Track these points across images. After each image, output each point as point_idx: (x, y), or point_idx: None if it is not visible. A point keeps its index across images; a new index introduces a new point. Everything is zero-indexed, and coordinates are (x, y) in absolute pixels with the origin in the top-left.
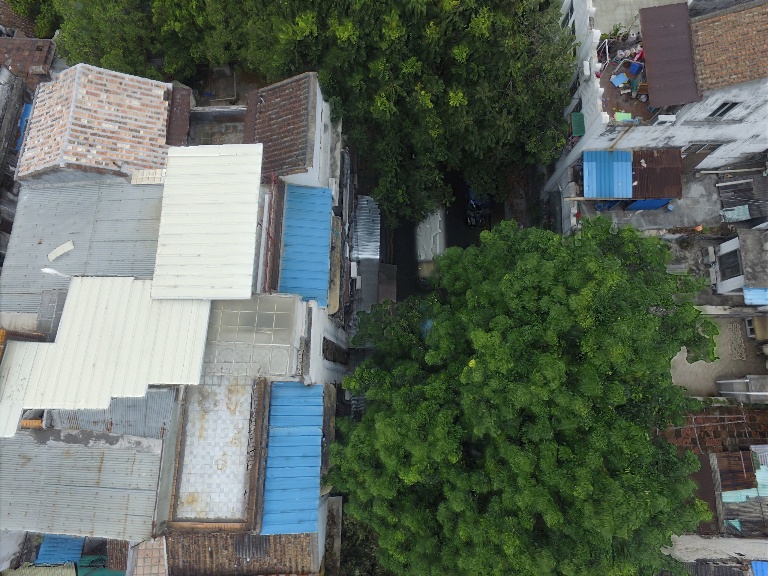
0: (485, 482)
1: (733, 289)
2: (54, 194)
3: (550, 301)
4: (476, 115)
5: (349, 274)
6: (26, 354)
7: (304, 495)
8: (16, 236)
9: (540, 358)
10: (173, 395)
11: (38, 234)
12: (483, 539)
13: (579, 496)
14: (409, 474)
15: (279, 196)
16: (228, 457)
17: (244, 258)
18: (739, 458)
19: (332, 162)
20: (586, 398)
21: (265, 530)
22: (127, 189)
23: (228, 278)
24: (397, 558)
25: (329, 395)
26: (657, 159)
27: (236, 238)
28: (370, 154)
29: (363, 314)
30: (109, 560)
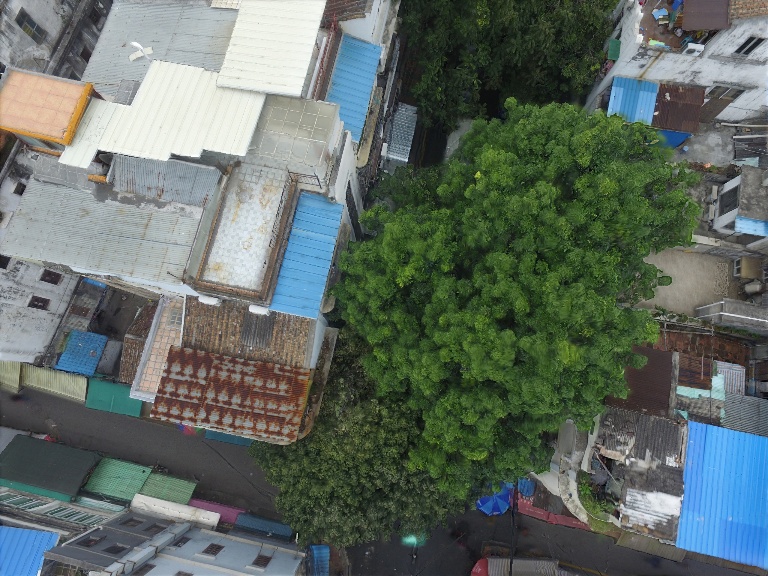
0: (469, 285)
1: (727, 223)
2: (142, 8)
3: (555, 144)
4: (522, 23)
5: (379, 152)
6: (106, 110)
7: (311, 288)
8: (104, 38)
9: (536, 182)
10: (219, 174)
11: (123, 38)
12: (459, 320)
13: (547, 290)
14: (406, 268)
15: (335, 41)
16: (254, 241)
17: (300, 64)
18: (700, 362)
19: (385, 34)
20: (569, 222)
21: (274, 306)
22: (206, 11)
23: (284, 77)
24: (380, 357)
25: (345, 232)
26: (681, 95)
27: (297, 47)
28: (418, 52)
29: (387, 175)
30: (121, 372)
